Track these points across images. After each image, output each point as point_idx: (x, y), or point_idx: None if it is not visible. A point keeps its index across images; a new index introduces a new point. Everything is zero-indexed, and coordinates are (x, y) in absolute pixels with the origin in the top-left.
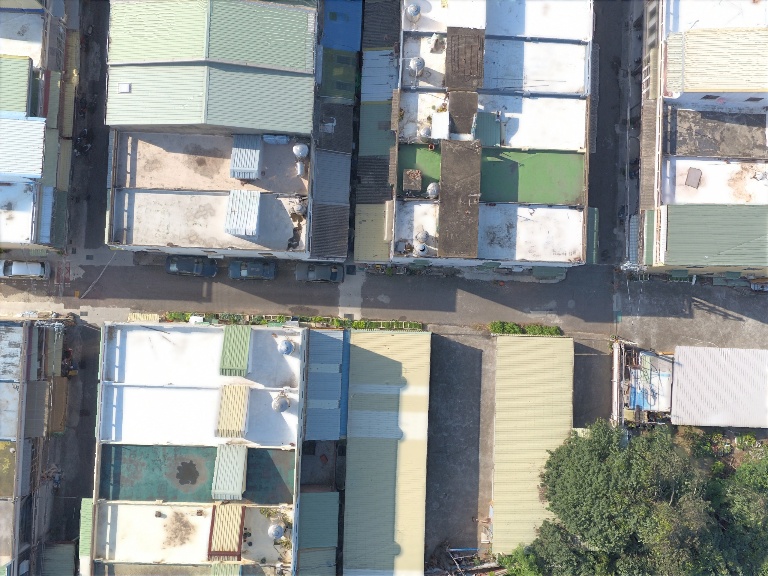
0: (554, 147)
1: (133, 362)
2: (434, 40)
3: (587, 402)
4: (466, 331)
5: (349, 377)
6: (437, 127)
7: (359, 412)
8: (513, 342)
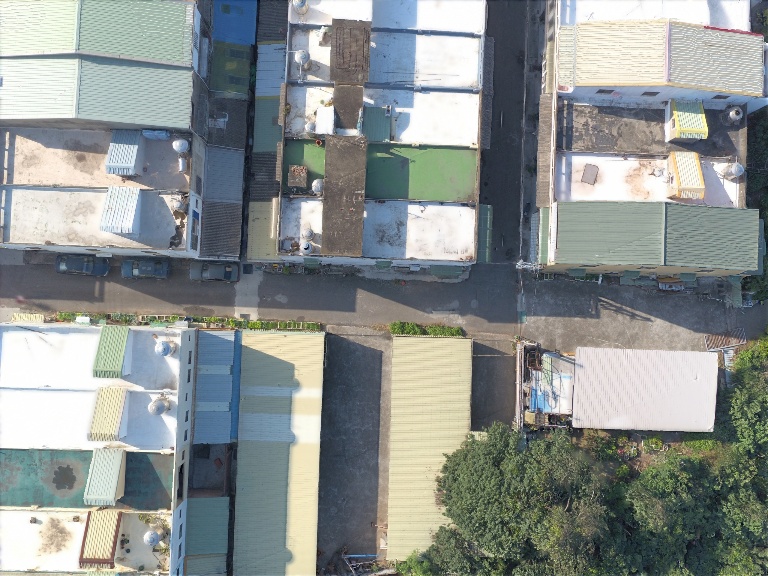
0: (445, 143)
1: (9, 363)
2: (322, 33)
3: (490, 404)
4: (366, 332)
5: (240, 379)
6: (321, 122)
7: (250, 415)
8: (409, 343)
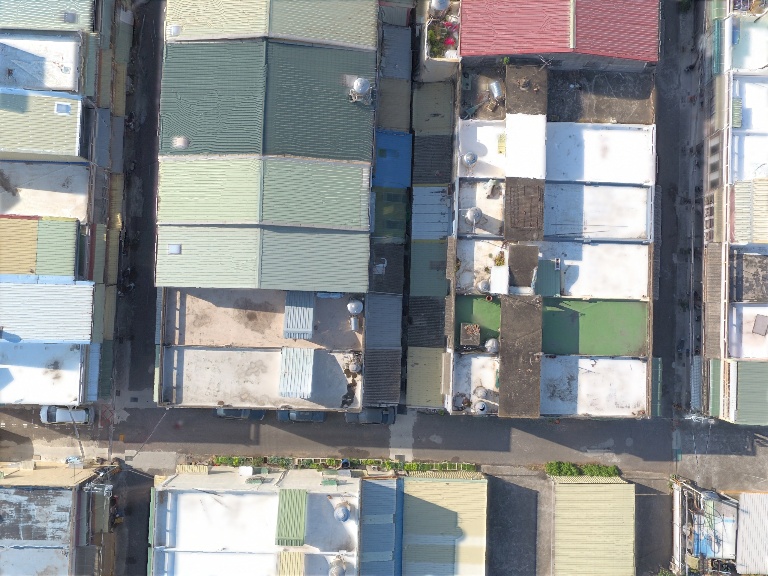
0: (616, 296)
1: (184, 526)
2: (491, 186)
3: (647, 544)
4: (521, 471)
5: (403, 527)
6: (496, 281)
7: (414, 564)
8: (572, 489)
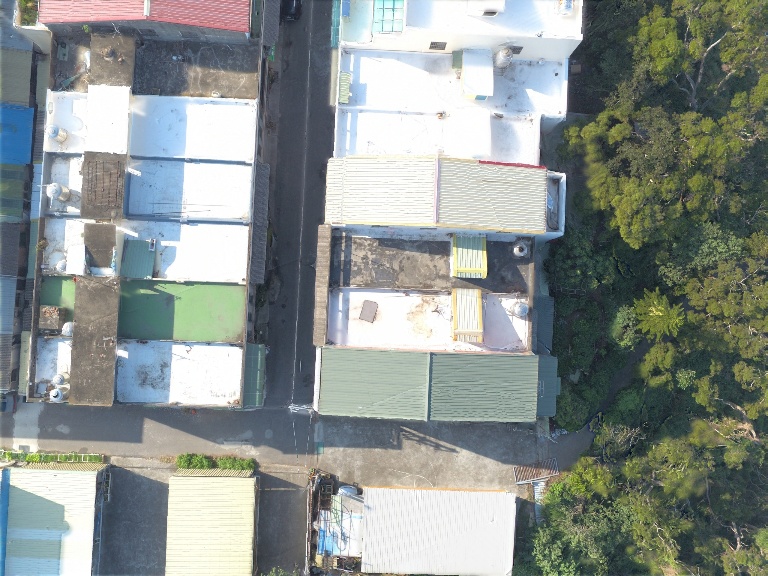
0: (212, 279)
1: None
2: (81, 162)
3: (283, 541)
4: (153, 464)
5: (7, 521)
6: (72, 262)
7: (17, 559)
8: (187, 483)
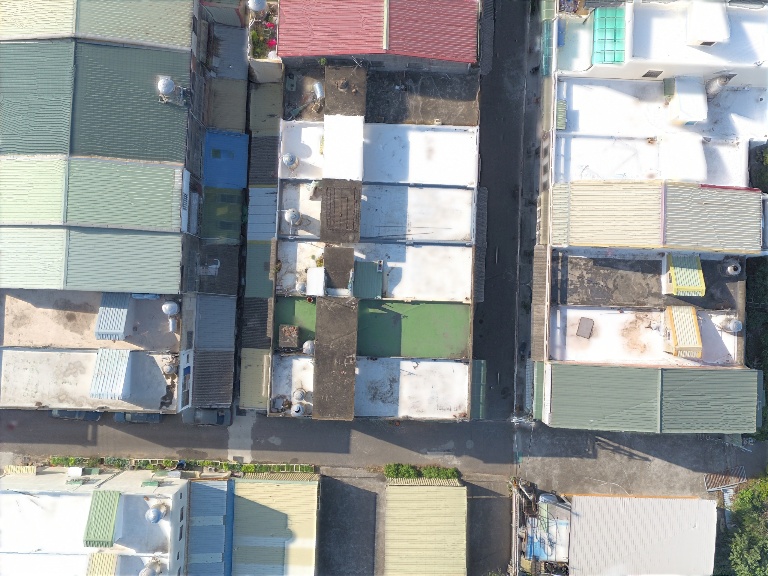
0: (438, 298)
1: (0, 527)
2: (313, 188)
3: (486, 547)
4: (360, 473)
5: (233, 529)
6: (312, 283)
7: (243, 565)
8: (403, 492)
